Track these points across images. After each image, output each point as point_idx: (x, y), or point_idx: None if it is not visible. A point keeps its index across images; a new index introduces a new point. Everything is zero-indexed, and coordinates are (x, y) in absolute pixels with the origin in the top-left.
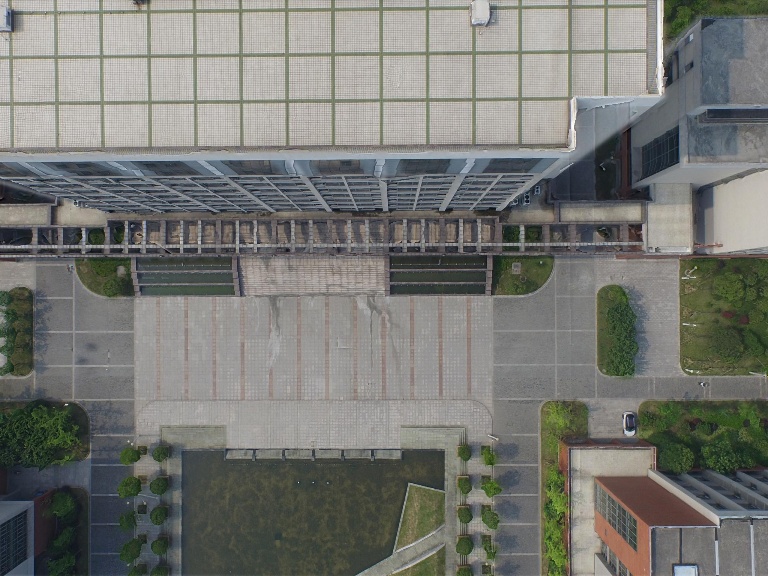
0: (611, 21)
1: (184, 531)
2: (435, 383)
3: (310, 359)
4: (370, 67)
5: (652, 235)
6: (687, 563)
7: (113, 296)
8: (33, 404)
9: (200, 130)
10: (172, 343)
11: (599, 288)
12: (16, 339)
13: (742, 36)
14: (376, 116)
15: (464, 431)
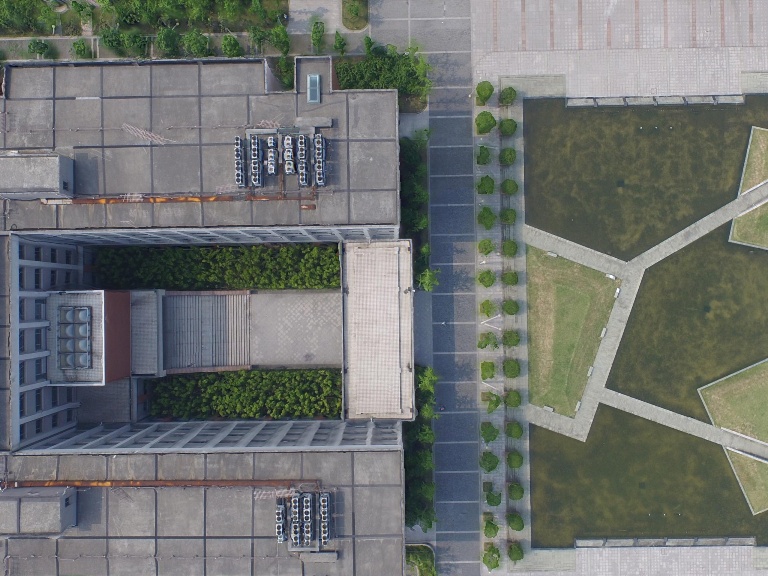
0: None
1: (526, 179)
2: None
3: (648, 8)
4: None
5: None
6: None
7: None
8: (380, 46)
9: None
10: None
11: None
12: None
13: None
14: None
15: None
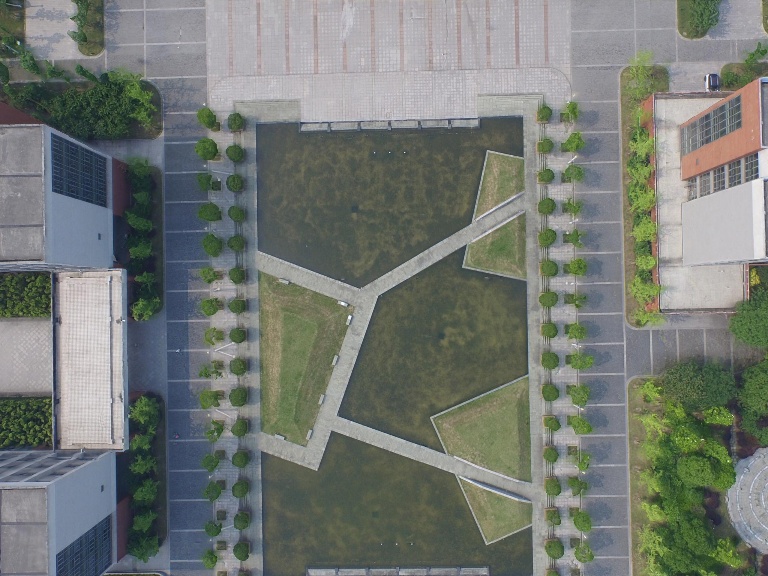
0: None
1: (259, 205)
2: (512, 52)
3: (384, 30)
4: None
5: None
6: None
7: None
8: None
9: None
10: (244, 18)
11: None
12: (87, 18)
13: None
14: None
15: (542, 98)
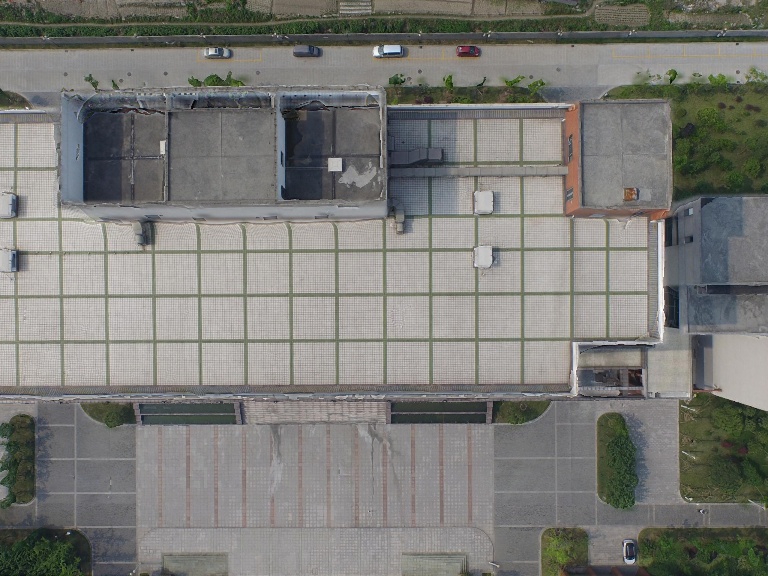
0: (612, 263)
1: None
2: (436, 510)
3: (311, 486)
4: (374, 307)
5: (652, 380)
6: None
7: None
8: (35, 536)
9: (205, 369)
10: (174, 470)
11: (599, 416)
12: (18, 467)
13: (741, 214)
14: (380, 356)
15: (465, 559)
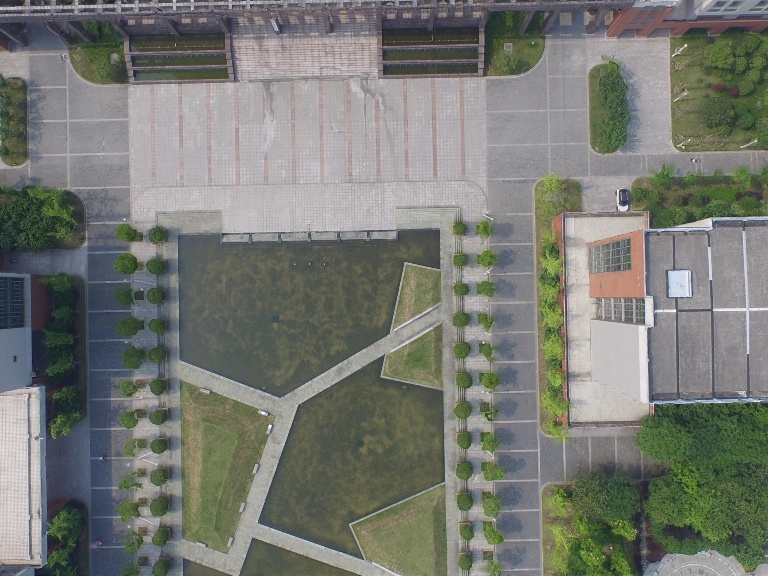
0: None
1: (181, 315)
2: (429, 165)
3: (305, 143)
4: None
5: None
6: (681, 269)
7: (107, 84)
8: (28, 186)
9: None
10: (167, 130)
11: (590, 67)
12: (10, 128)
13: None
14: None
15: (459, 211)
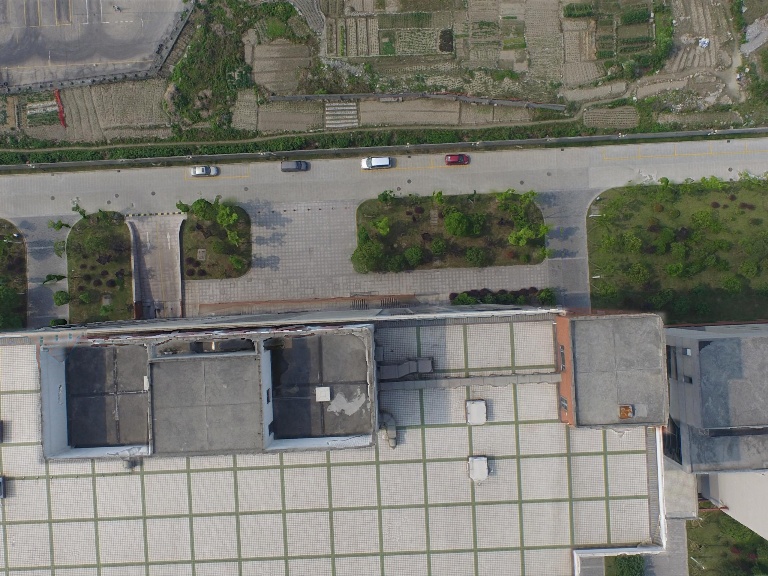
0: (611, 468)
1: None
2: None
3: None
4: (369, 521)
5: None
6: None
7: None
8: None
9: None
10: None
11: None
12: None
13: (740, 356)
14: (377, 570)
15: None
